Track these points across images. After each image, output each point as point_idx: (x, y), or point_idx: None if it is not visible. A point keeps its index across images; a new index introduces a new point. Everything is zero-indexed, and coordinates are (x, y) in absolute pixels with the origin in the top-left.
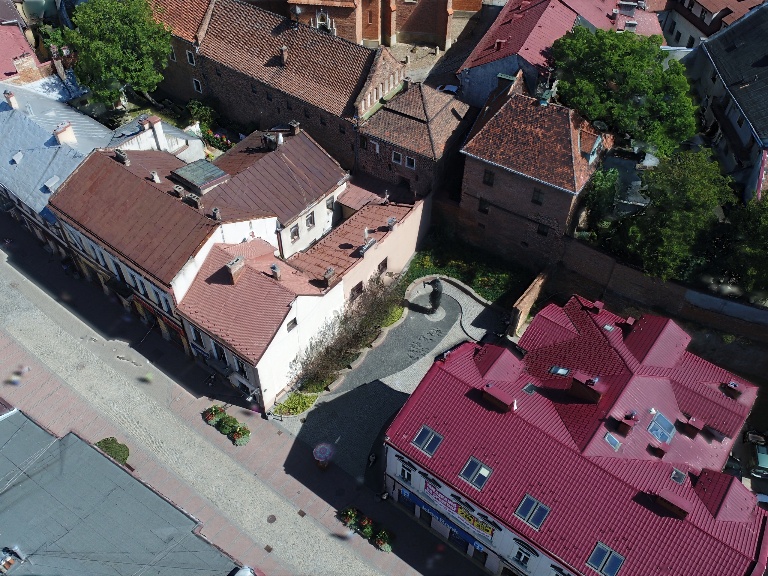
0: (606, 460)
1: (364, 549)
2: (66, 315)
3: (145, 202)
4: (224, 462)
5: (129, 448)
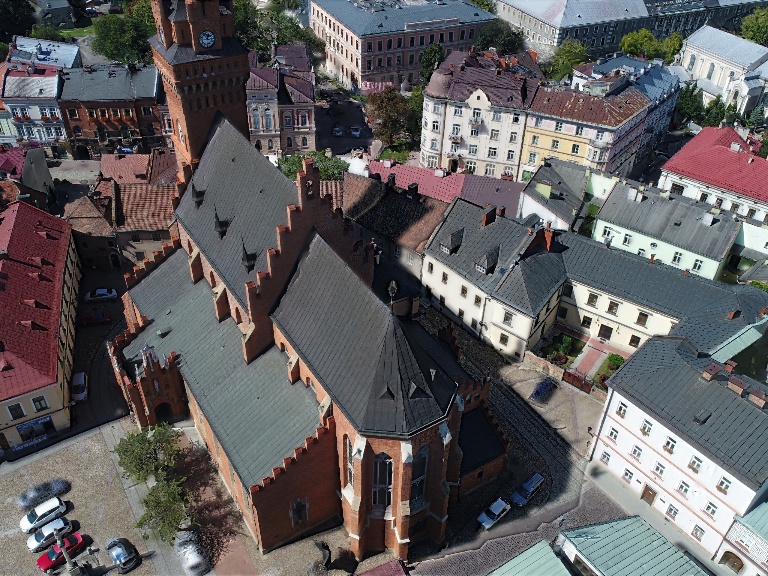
0: None
1: None
2: None
3: None
4: None
5: None
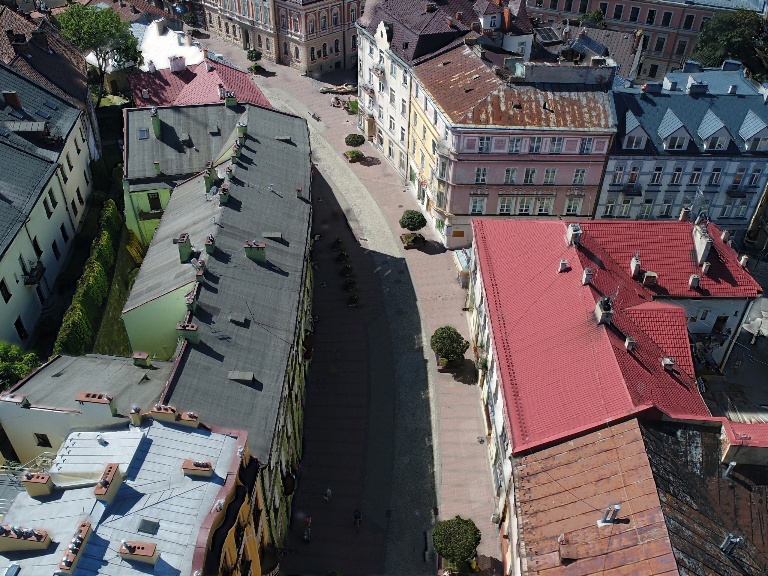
0: None
1: None
2: None
3: (132, 2)
4: None
5: None
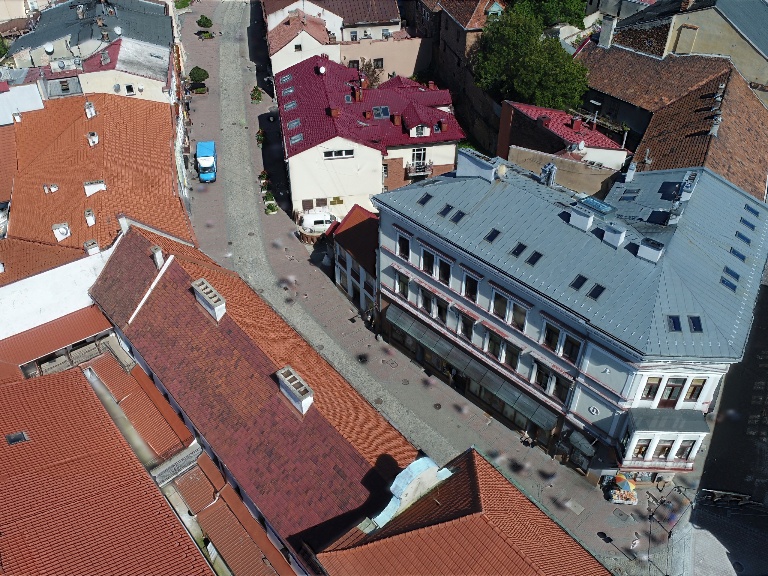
0: (336, 100)
1: (253, 144)
2: (246, 49)
3: None
4: (241, 105)
5: (215, 88)
